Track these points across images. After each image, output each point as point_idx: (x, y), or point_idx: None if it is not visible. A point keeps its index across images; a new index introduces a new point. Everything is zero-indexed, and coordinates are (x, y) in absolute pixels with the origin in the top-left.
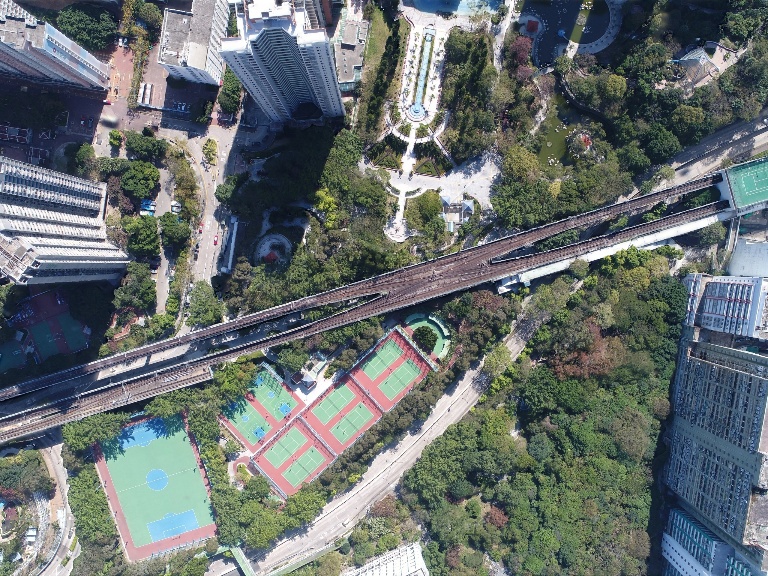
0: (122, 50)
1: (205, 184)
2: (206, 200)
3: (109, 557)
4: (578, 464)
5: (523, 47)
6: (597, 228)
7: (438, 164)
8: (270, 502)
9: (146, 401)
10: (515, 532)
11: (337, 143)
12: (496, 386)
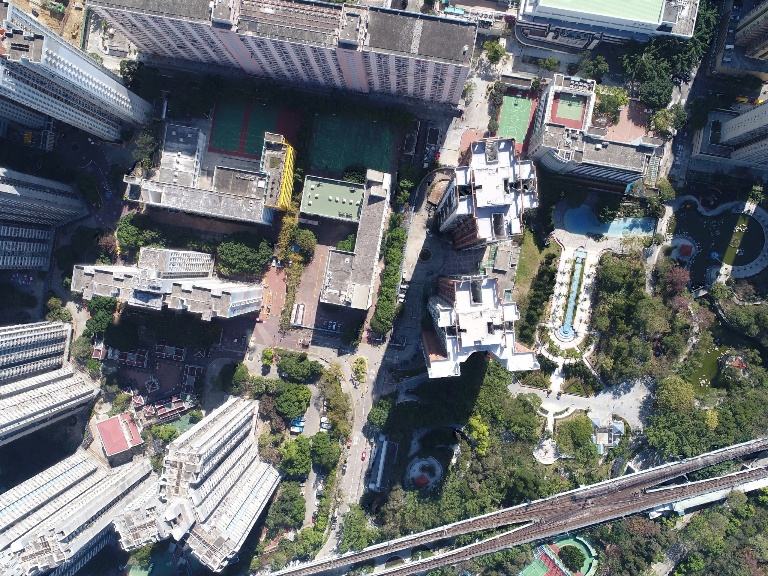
0: (275, 270)
1: (354, 401)
2: (355, 416)
3: None
4: None
5: (681, 280)
6: None
7: (587, 385)
8: None
9: None
10: None
11: (489, 369)
12: None
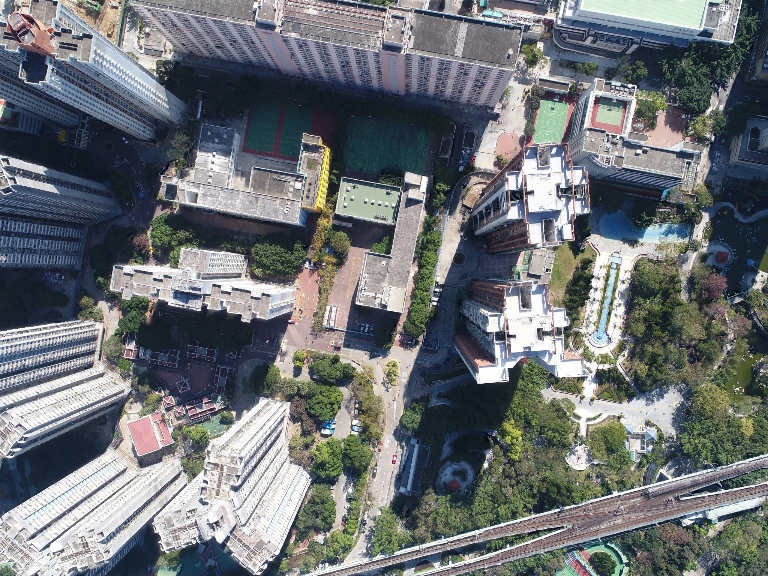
0: (308, 271)
1: (385, 404)
2: (386, 419)
3: None
4: None
5: (718, 287)
6: None
7: (620, 391)
8: None
9: None
10: None
11: (523, 374)
12: None
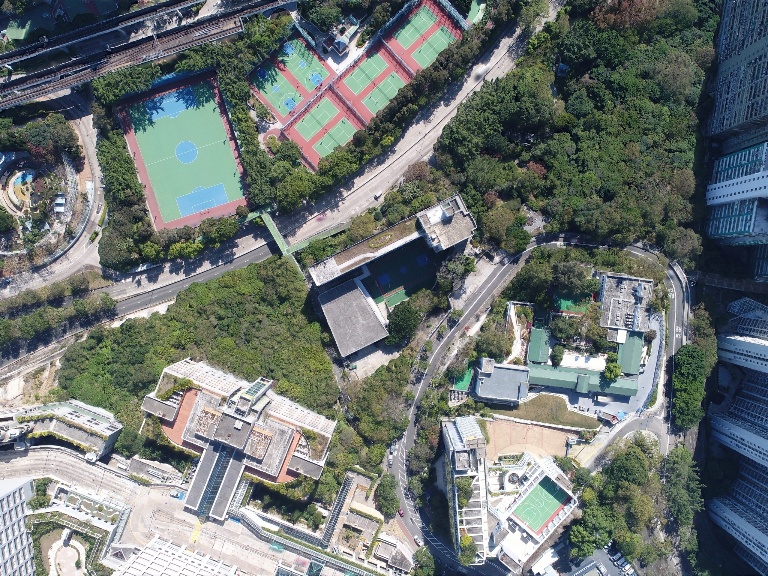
0: None
1: None
2: None
3: (138, 215)
4: (619, 110)
5: None
6: None
7: None
8: (301, 168)
9: (176, 59)
10: (554, 178)
11: None
12: (533, 41)
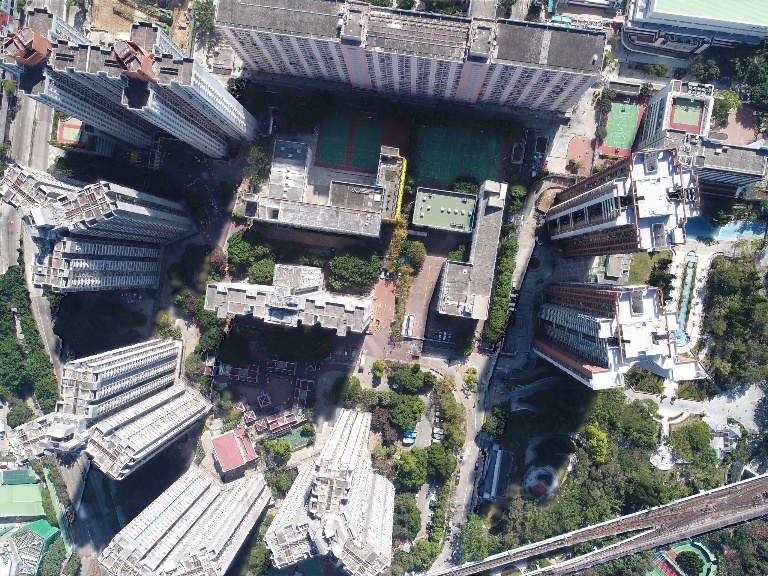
0: (383, 282)
1: None
2: (467, 426)
3: None
4: None
5: None
6: None
7: (702, 389)
8: None
9: None
10: None
11: None
12: None
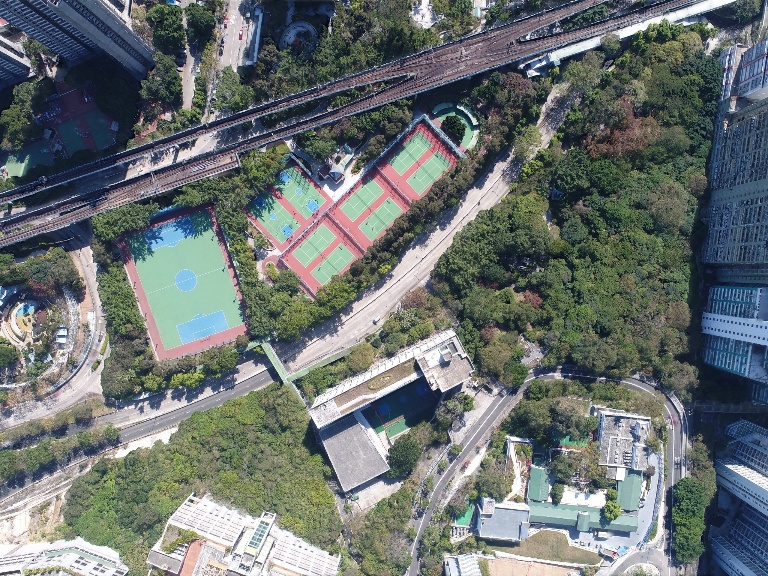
0: None
1: None
2: None
3: (140, 349)
4: (613, 240)
5: None
6: (627, 10)
7: None
8: (300, 297)
9: (174, 193)
10: (550, 310)
11: None
12: (527, 170)
